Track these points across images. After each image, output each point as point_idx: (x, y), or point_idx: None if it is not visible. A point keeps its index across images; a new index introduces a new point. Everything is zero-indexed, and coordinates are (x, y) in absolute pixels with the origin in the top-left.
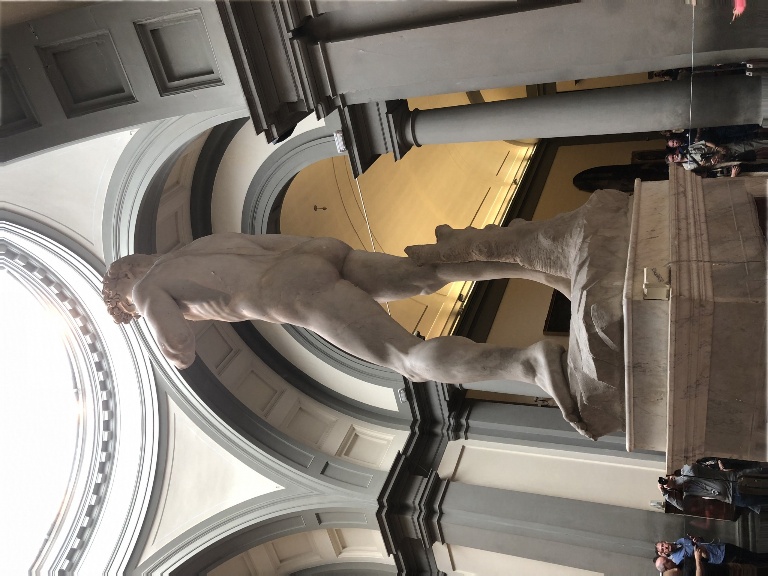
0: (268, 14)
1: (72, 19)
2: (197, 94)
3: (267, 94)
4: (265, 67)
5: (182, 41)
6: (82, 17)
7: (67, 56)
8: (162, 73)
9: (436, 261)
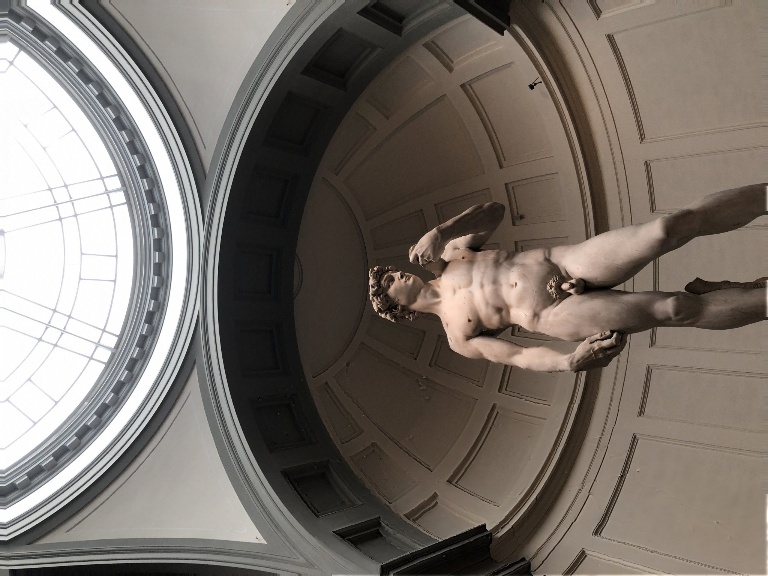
0: (480, 573)
1: (357, 484)
2: (356, 553)
3: (421, 575)
4: (439, 574)
5: (386, 549)
6: (363, 489)
7: (324, 482)
8: (350, 536)
9: (714, 283)
